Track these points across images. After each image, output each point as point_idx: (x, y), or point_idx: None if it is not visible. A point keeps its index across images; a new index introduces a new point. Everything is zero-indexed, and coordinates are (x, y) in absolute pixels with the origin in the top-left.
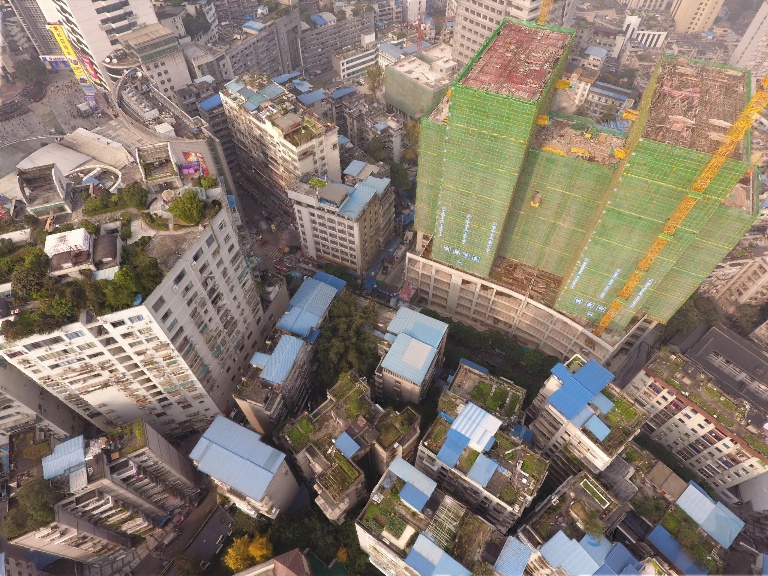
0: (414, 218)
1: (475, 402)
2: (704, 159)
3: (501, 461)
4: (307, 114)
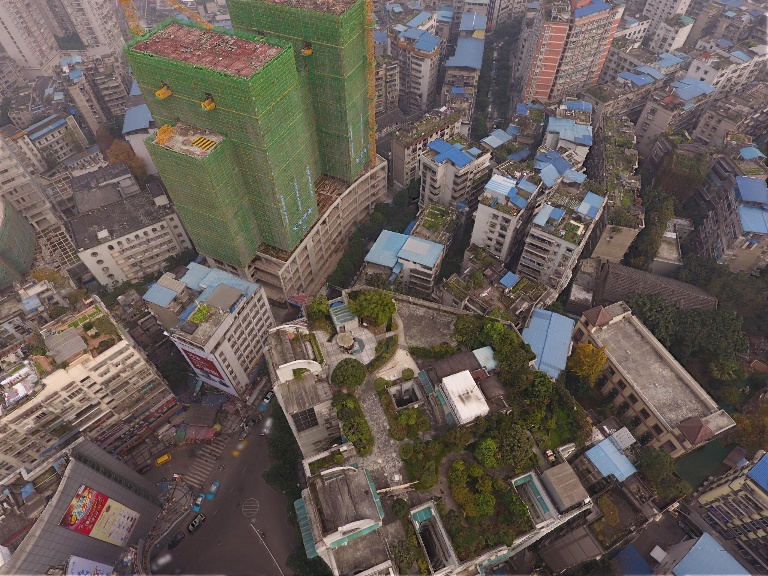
0: (239, 259)
1: (440, 230)
2: (360, 4)
3: (519, 179)
4: (53, 327)
